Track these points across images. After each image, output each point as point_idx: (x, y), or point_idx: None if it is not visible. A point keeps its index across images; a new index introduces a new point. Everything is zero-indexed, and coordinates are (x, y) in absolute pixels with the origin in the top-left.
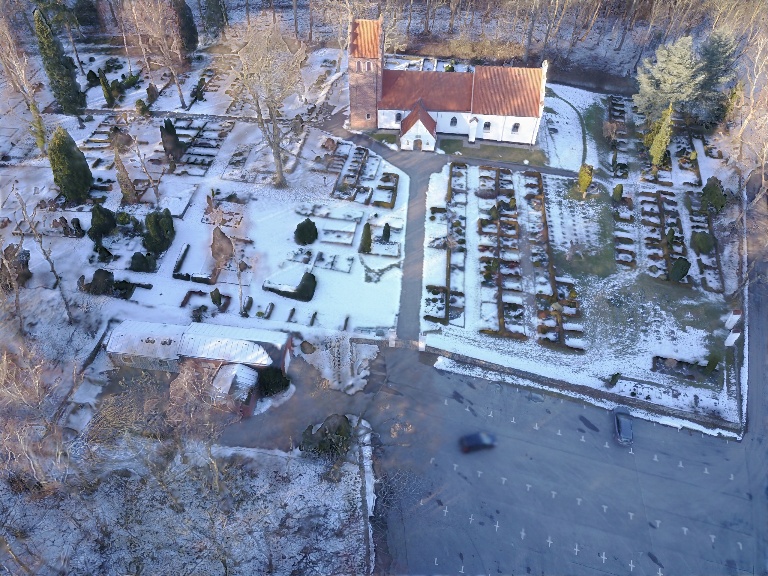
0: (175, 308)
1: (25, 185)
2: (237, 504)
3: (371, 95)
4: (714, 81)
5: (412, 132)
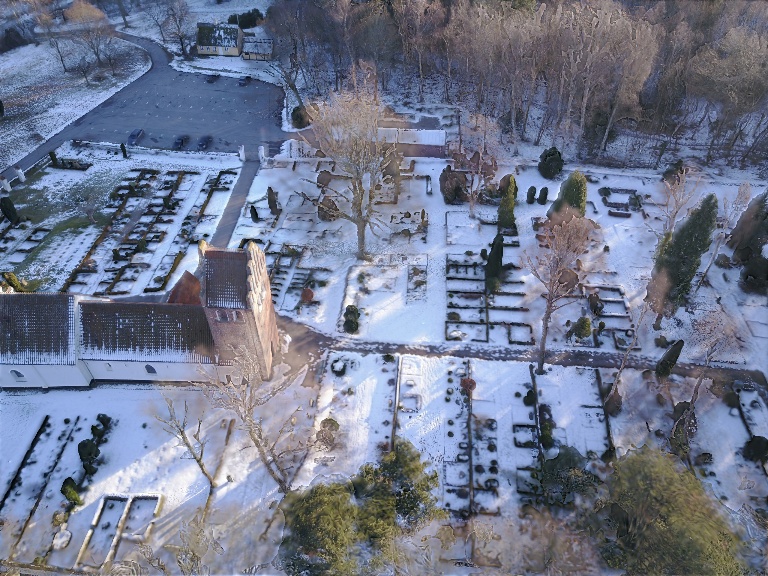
0: (417, 159)
1: (639, 248)
2: None
3: None
4: None
5: None
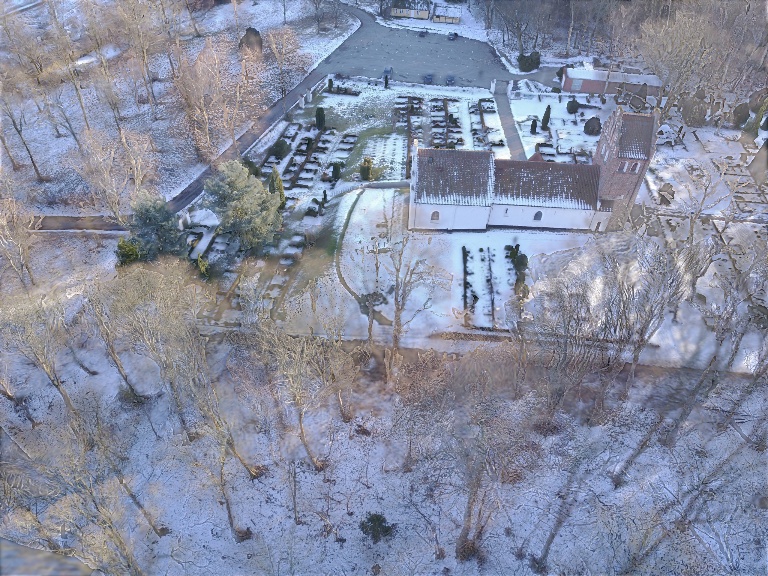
0: None
1: None
2: None
3: None
4: None
5: None
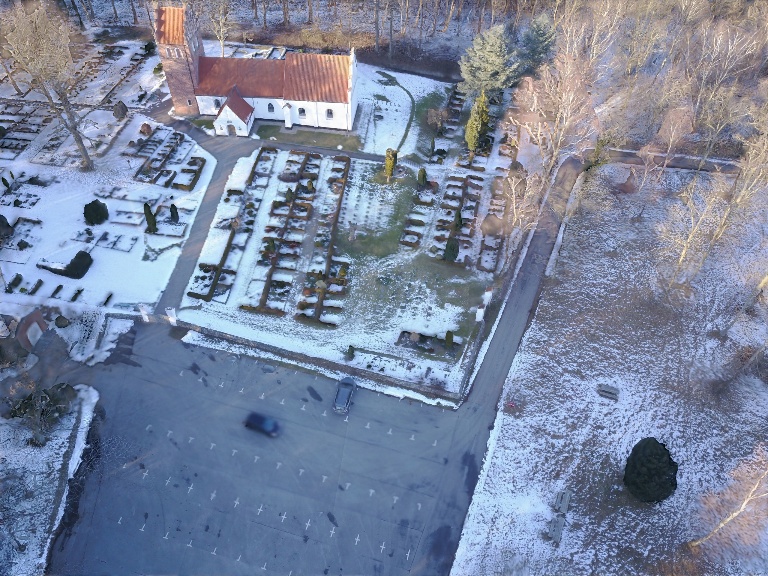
0: None
1: None
2: None
3: (187, 81)
4: (538, 69)
5: (223, 117)
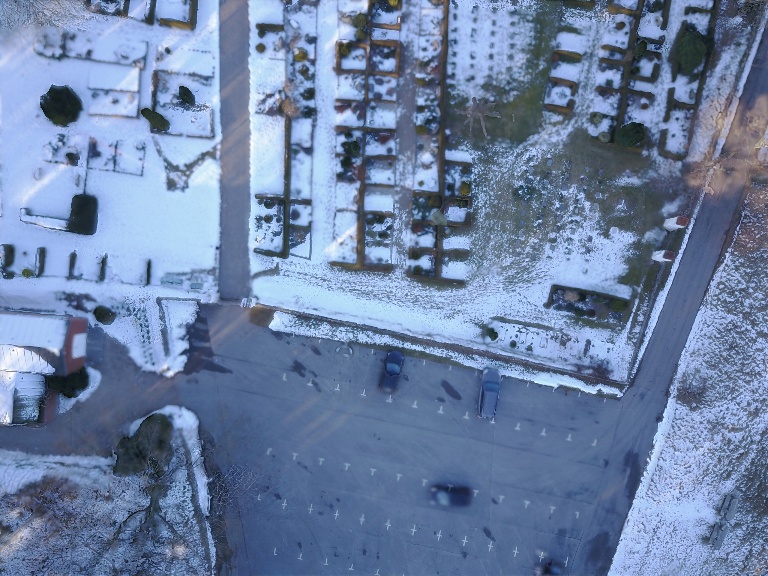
0: None
1: None
2: (65, 523)
3: None
4: None
5: None
